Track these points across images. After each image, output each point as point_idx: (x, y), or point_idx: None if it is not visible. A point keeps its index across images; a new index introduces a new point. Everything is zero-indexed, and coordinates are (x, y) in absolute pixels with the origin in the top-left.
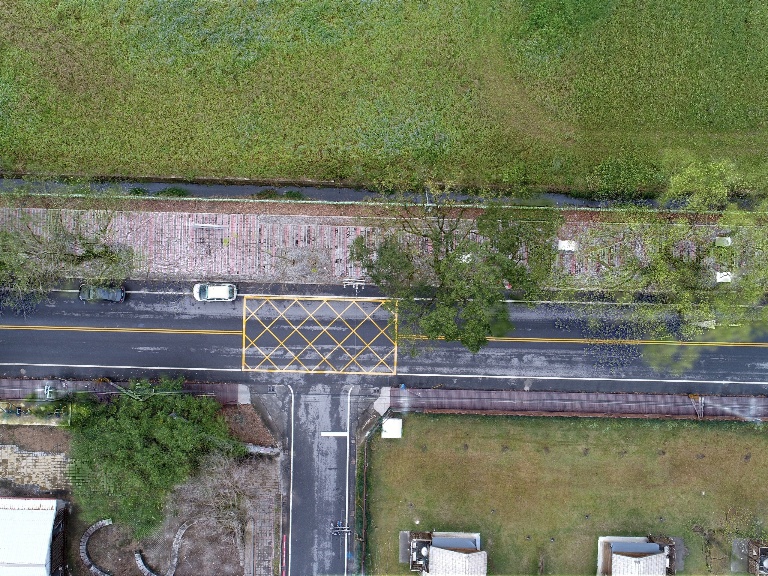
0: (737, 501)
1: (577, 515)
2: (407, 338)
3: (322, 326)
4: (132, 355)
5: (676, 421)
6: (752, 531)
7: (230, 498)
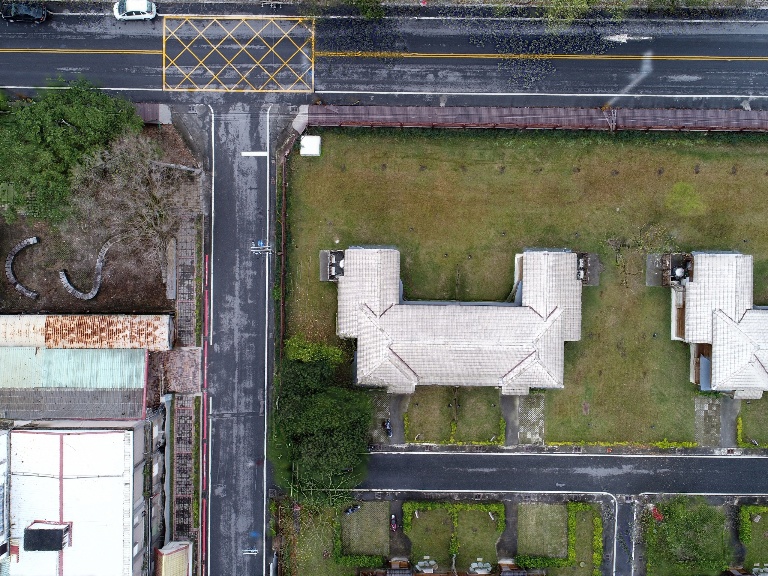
0: (651, 217)
1: (494, 233)
2: (324, 55)
3: (241, 44)
4: (55, 76)
5: (590, 137)
6: (666, 246)
7: (153, 217)
